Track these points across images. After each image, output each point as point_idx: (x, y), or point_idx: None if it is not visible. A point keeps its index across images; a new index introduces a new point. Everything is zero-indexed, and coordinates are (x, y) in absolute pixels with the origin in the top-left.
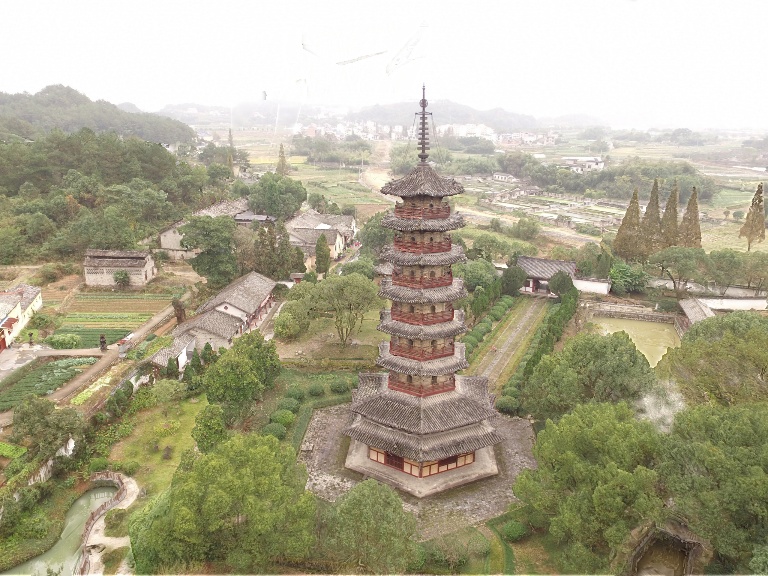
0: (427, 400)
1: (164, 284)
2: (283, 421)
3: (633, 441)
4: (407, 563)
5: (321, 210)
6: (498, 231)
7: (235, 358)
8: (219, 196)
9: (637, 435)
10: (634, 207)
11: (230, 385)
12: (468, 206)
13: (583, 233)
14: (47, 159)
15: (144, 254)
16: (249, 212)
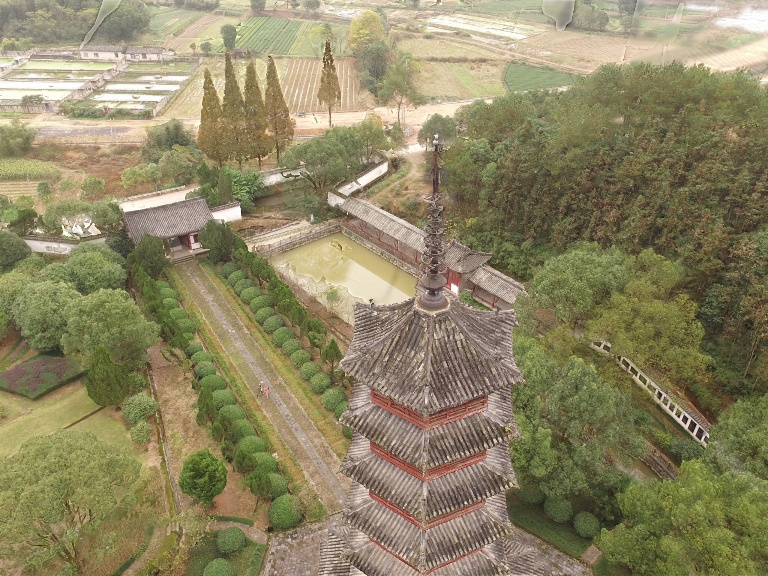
0: None
1: None
2: None
3: None
4: None
5: None
6: None
7: None
8: None
9: None
10: (211, 94)
11: None
12: None
13: (80, 118)
14: None
15: None
16: None
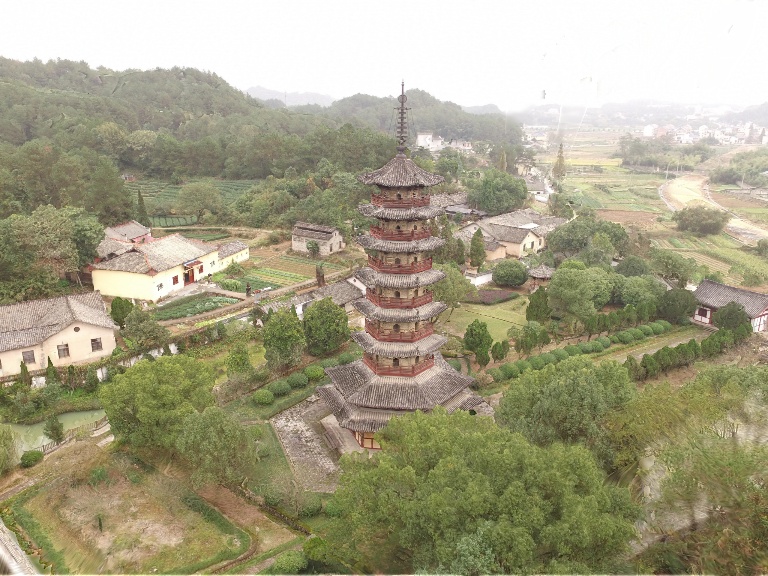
0: (382, 378)
1: (343, 257)
2: (310, 374)
3: (428, 444)
4: (219, 481)
5: (555, 211)
6: (763, 255)
7: (281, 312)
8: (445, 189)
9: (437, 441)
10: None
11: (276, 334)
12: (764, 224)
13: None
14: (311, 149)
15: (332, 230)
16: (462, 205)
